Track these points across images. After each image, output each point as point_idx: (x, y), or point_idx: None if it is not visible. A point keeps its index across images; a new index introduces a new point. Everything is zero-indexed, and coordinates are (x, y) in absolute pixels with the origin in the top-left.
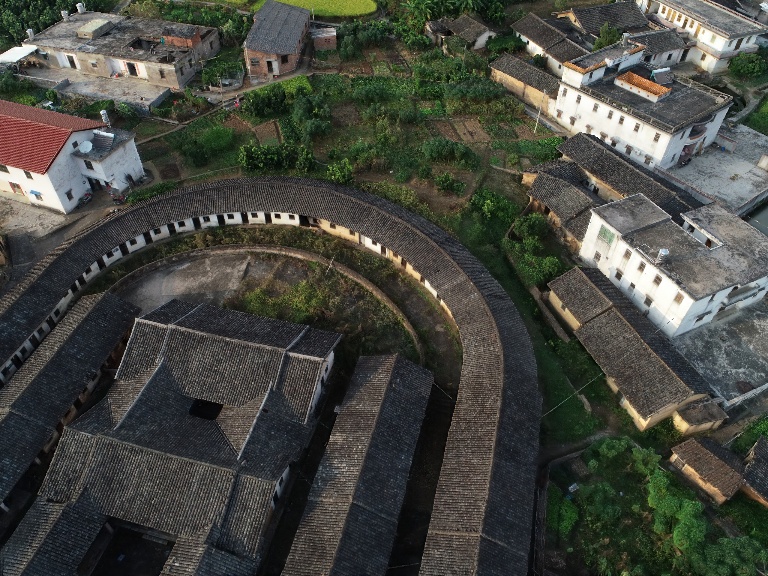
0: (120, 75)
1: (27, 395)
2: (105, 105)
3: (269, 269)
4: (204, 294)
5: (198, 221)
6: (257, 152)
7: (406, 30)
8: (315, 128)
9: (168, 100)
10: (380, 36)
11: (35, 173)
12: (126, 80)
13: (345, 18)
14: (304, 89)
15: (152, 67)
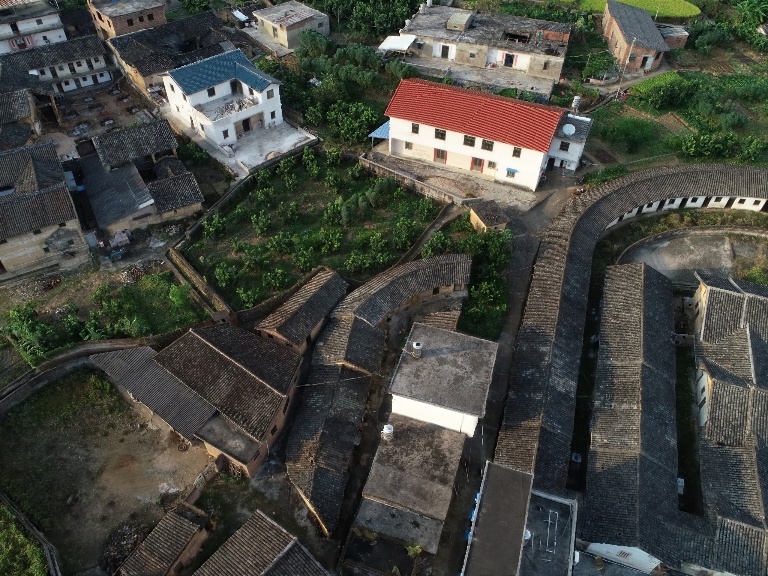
0: (494, 66)
1: (646, 350)
2: (514, 93)
3: (754, 250)
4: (701, 270)
5: (663, 203)
6: (704, 141)
7: (751, 32)
8: (737, 121)
9: (557, 90)
10: (728, 37)
11: (528, 152)
12: (501, 70)
13: (676, 19)
14: (699, 84)
15: (538, 59)
